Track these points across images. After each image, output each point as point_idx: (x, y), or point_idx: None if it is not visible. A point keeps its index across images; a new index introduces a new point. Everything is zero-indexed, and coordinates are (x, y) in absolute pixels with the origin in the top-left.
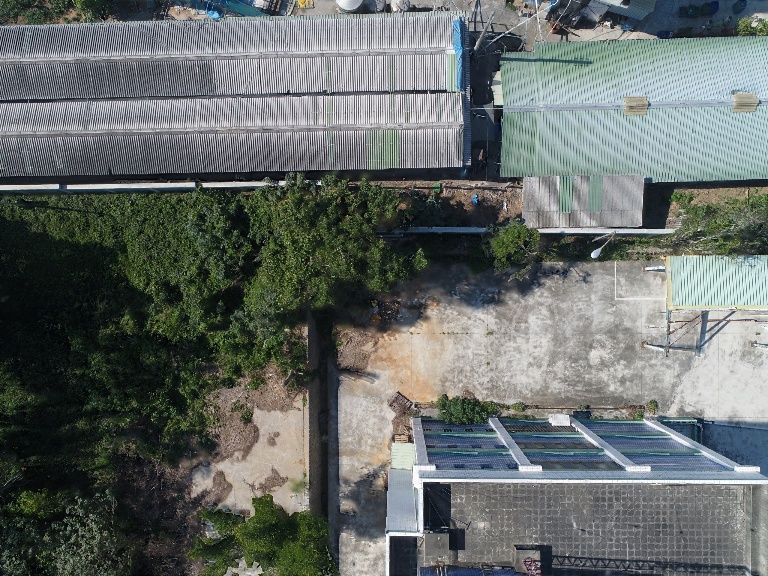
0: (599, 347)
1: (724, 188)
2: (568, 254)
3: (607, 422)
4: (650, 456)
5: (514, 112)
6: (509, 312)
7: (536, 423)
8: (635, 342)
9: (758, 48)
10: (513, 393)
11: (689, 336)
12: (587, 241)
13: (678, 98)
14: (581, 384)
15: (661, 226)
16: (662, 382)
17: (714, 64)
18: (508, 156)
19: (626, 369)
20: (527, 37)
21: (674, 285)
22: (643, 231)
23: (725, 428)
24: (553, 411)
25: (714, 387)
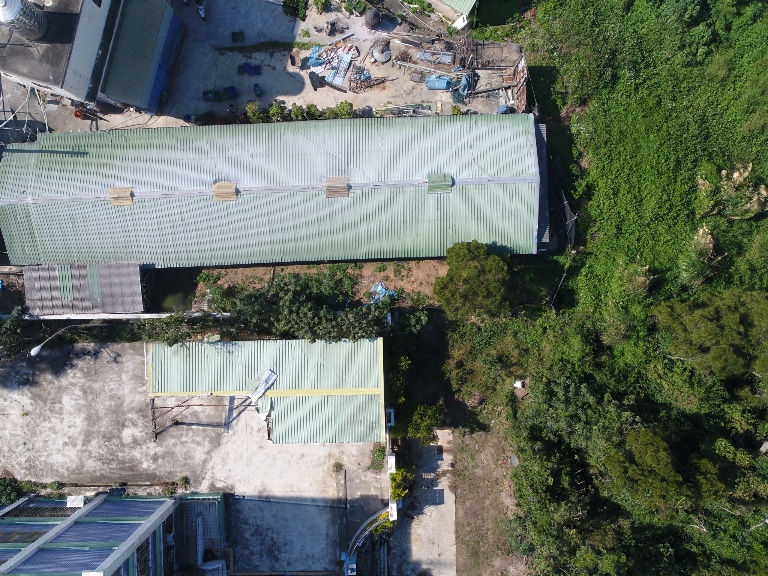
0: (131, 426)
1: (251, 267)
2: (96, 336)
3: (134, 500)
4: (66, 551)
5: (4, 205)
6: (44, 393)
7: (64, 502)
8: (166, 420)
9: (250, 136)
10: (50, 472)
11: (217, 413)
12: (113, 323)
13: (162, 188)
14: (115, 462)
15: (188, 306)
16: (193, 459)
17: (205, 153)
18: (12, 245)
19: (158, 447)
20: (55, 123)
21: (154, 372)
22: (146, 316)
23: (255, 502)
24: (89, 489)
25: (243, 463)
